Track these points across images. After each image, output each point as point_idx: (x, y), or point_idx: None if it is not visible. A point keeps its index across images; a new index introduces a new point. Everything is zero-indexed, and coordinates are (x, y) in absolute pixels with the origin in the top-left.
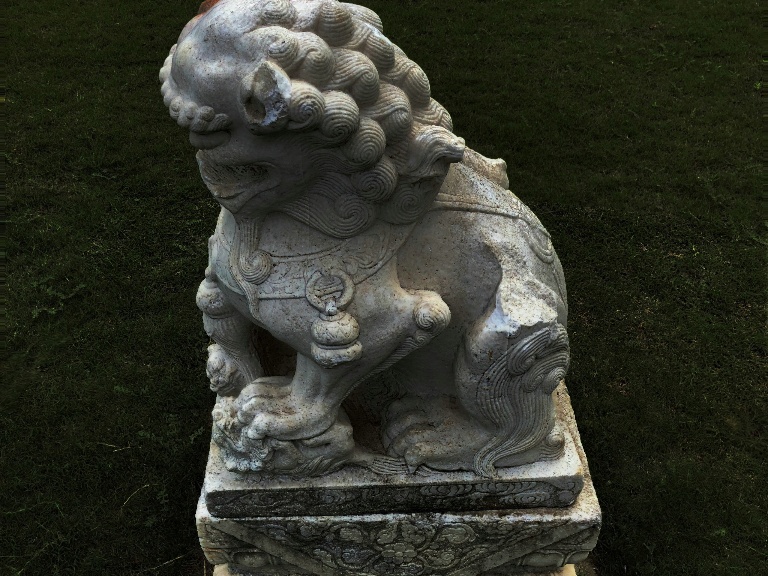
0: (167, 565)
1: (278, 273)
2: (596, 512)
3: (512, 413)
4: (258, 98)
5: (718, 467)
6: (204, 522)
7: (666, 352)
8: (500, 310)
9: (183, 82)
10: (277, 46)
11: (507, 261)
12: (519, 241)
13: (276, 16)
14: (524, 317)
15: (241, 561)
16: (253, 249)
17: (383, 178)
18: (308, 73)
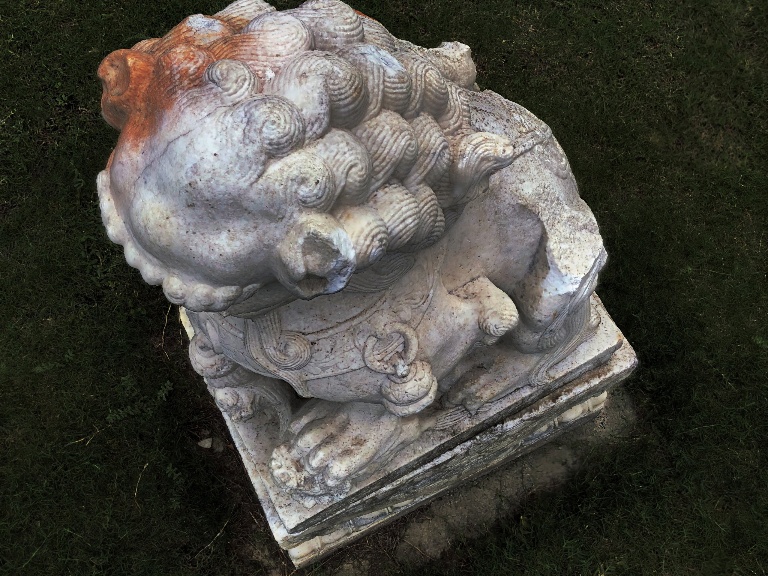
0: (220, 537)
1: (322, 352)
2: (632, 356)
3: (564, 333)
4: (317, 275)
5: (658, 196)
6: (286, 540)
7: (569, 78)
8: (557, 272)
9: (175, 262)
10: (311, 192)
11: (543, 209)
12: (545, 176)
13: (286, 142)
14: (580, 266)
15: (321, 535)
16: (278, 334)
17: (437, 232)
18: (353, 197)
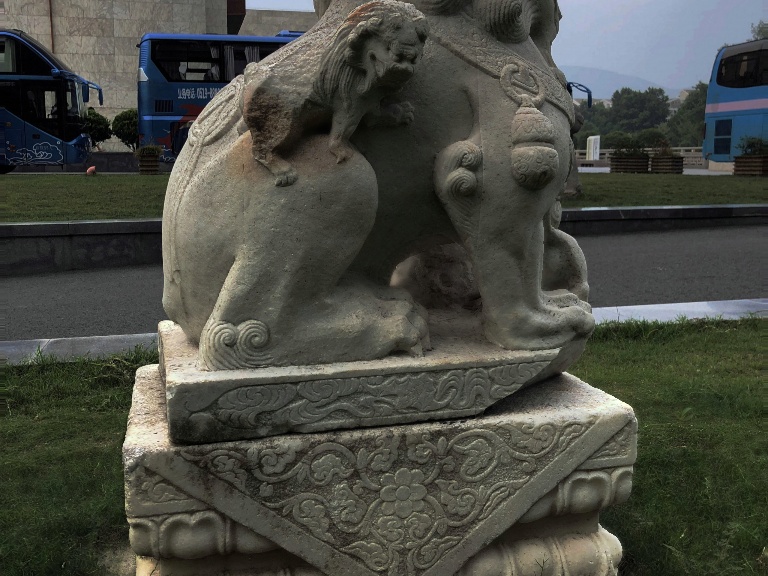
0: None
1: None
2: None
3: None
4: None
5: None
6: None
7: None
8: None
9: None
10: None
11: None
12: None
13: None
14: None
15: None
16: None
17: None
18: None
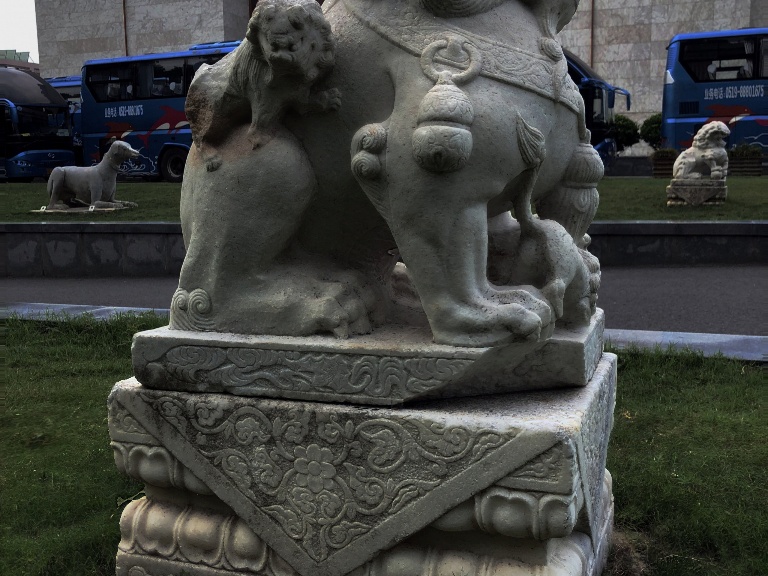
0: None
1: None
2: None
3: None
4: None
5: None
6: None
7: None
8: None
9: None
10: None
11: None
12: None
13: None
14: None
15: None
16: None
17: None
18: None
